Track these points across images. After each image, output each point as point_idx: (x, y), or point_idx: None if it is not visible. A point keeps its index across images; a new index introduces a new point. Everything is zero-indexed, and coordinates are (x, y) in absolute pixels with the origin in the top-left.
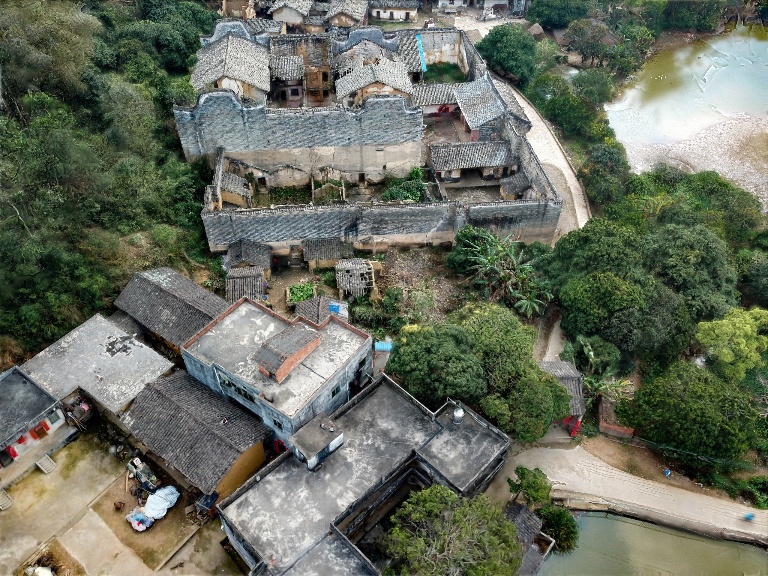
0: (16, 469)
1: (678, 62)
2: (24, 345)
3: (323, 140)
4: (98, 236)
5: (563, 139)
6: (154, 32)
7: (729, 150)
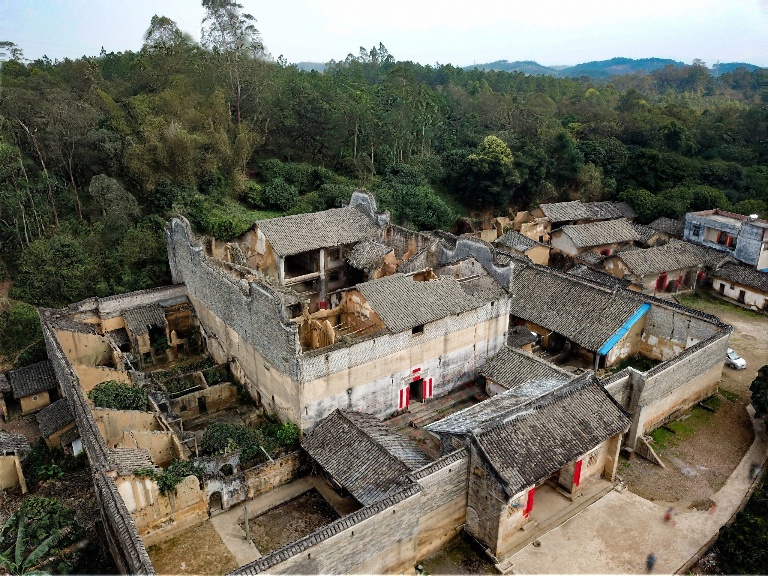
0: None
1: None
2: None
3: (231, 319)
4: None
5: None
6: (337, 193)
7: None
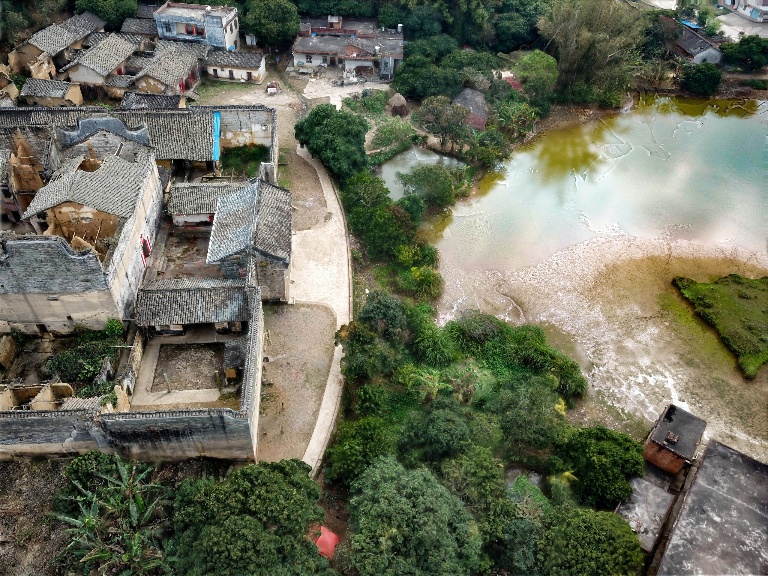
0: None
1: (562, 148)
2: None
3: None
4: None
5: (369, 261)
6: None
7: (580, 284)
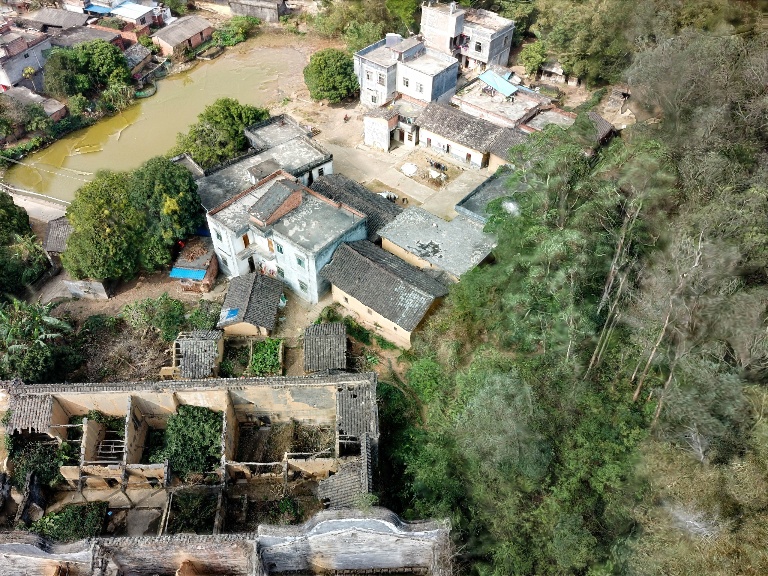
0: None
1: None
2: None
3: None
4: None
5: None
6: None
7: None
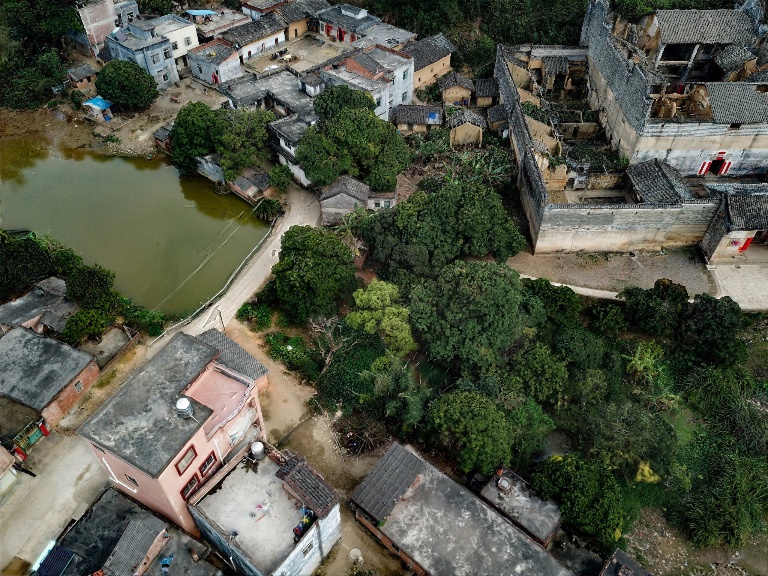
0: (338, 44)
1: None
2: (398, 22)
3: (612, 83)
4: (451, 3)
5: None
6: None
7: None
